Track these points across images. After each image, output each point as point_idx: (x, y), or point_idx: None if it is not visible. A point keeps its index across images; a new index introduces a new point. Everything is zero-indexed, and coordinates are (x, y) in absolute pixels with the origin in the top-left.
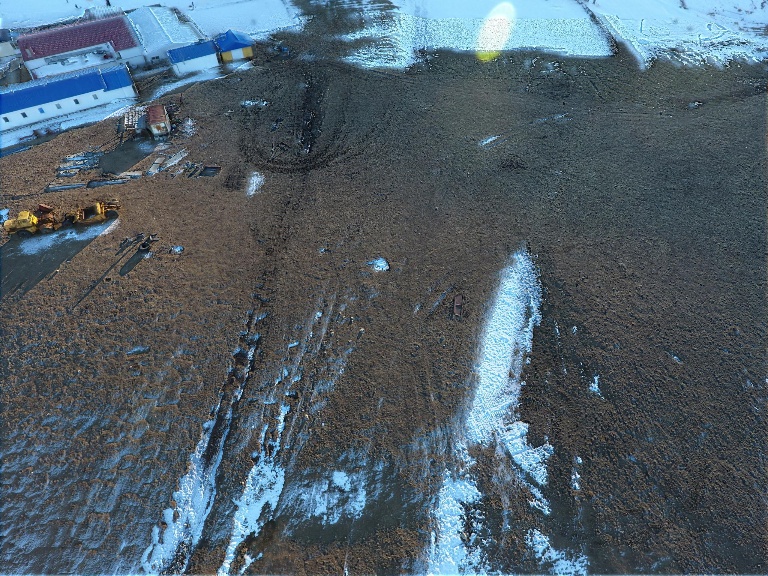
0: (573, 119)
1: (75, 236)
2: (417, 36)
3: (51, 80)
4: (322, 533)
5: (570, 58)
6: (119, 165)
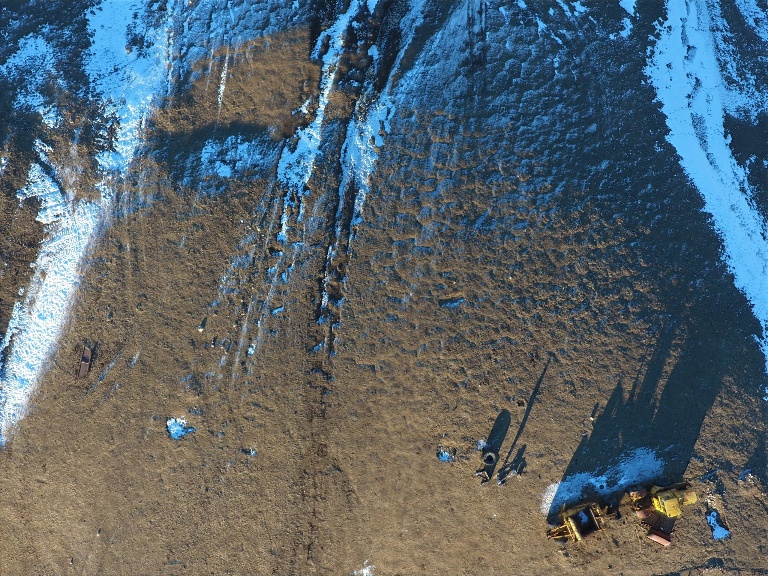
0: None
1: (594, 480)
2: None
3: None
4: (241, 129)
5: None
6: None
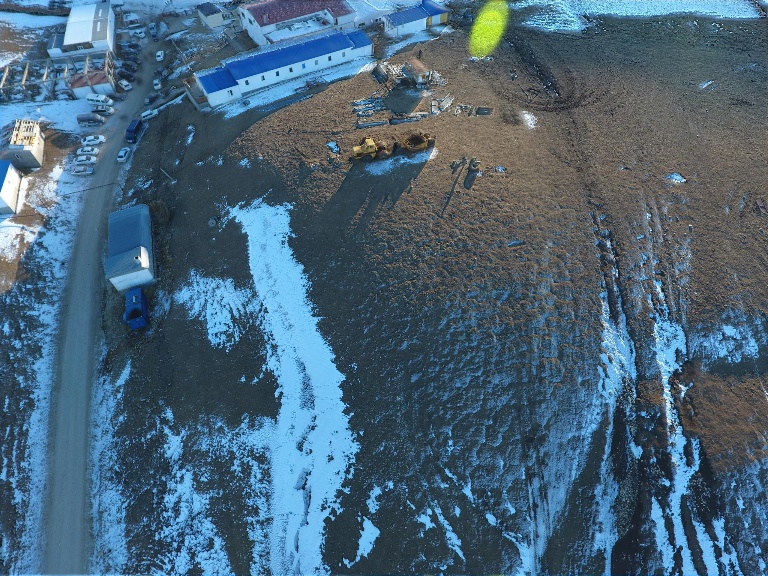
0: (766, 67)
1: (408, 160)
2: (574, 5)
3: (306, 39)
4: (733, 368)
5: (726, 20)
6: (403, 107)
